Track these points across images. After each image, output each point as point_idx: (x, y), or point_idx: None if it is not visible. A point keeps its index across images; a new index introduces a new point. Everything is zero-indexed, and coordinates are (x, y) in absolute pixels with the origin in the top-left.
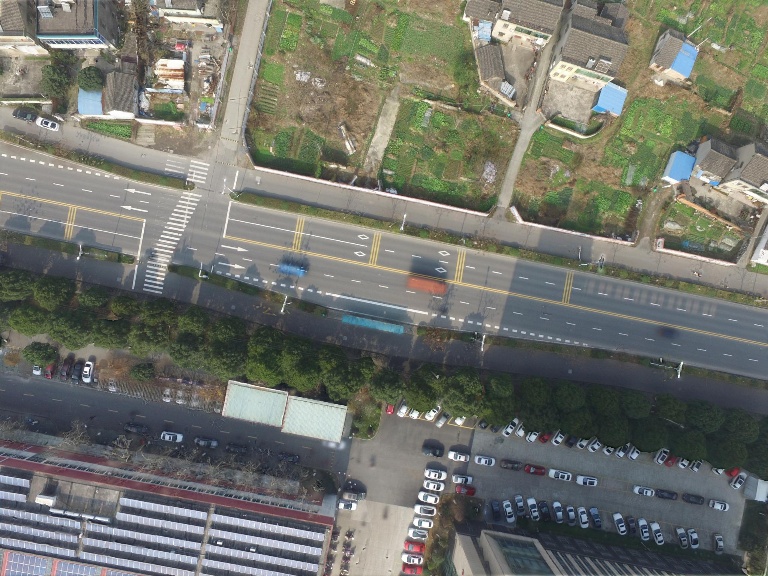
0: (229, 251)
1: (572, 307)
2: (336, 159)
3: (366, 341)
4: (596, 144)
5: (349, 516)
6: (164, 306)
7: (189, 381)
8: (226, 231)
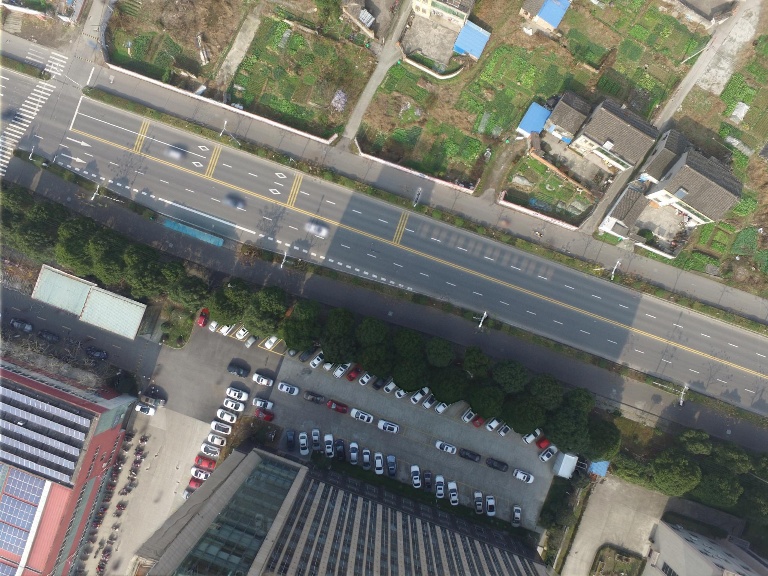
0: (73, 144)
1: (402, 248)
2: (189, 68)
3: (191, 251)
4: (453, 86)
5: (147, 421)
6: None
7: (16, 264)
8: (73, 124)
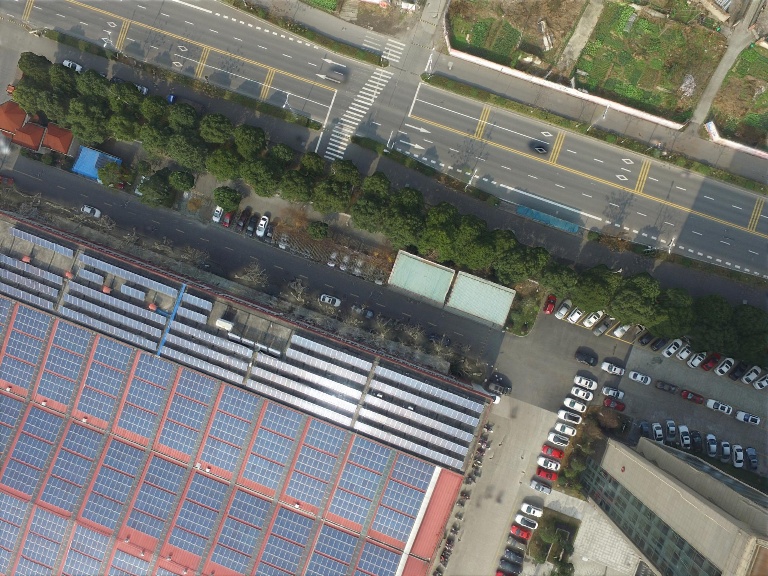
0: (412, 130)
1: (758, 235)
2: None
3: (534, 238)
4: None
5: (490, 409)
6: (353, 166)
7: (354, 250)
8: (412, 111)
